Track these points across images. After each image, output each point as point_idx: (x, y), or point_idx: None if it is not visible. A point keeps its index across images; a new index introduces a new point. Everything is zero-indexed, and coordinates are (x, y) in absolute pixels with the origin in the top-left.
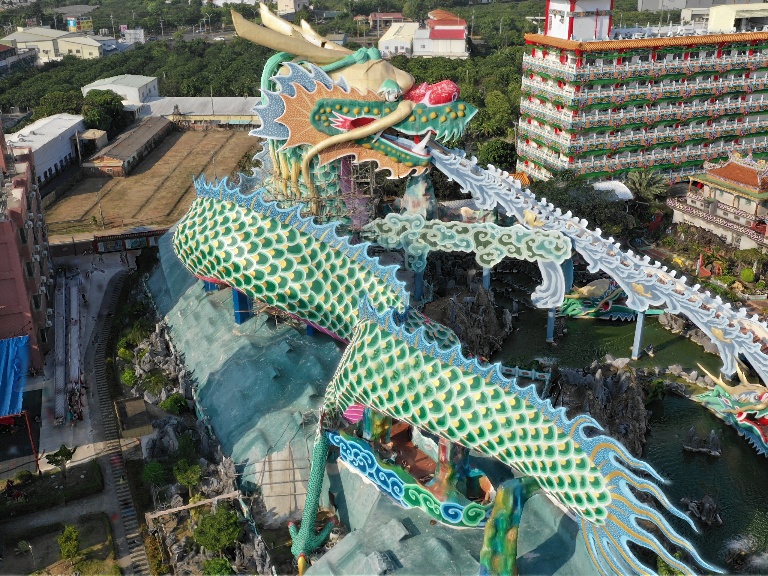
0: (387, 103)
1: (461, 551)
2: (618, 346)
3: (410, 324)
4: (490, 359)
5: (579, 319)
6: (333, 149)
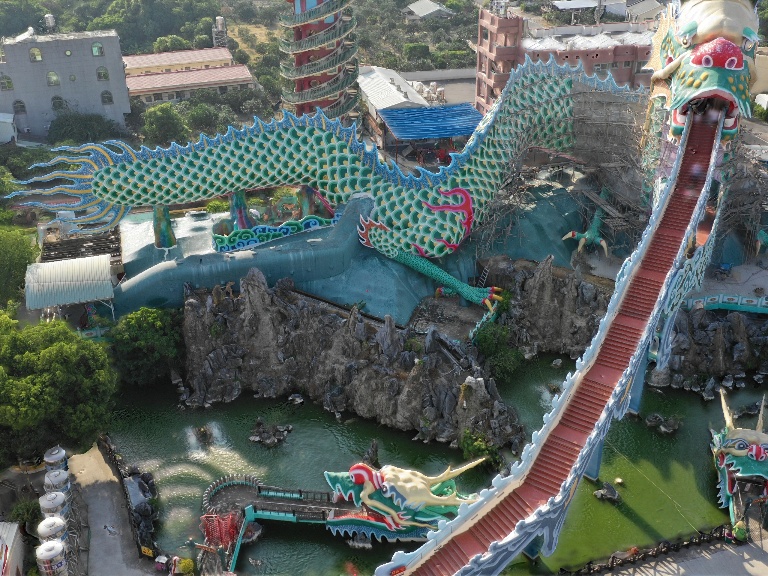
0: (682, 47)
1: (192, 234)
2: (616, 462)
3: (409, 190)
4: (573, 359)
5: (709, 451)
6: (660, 84)
